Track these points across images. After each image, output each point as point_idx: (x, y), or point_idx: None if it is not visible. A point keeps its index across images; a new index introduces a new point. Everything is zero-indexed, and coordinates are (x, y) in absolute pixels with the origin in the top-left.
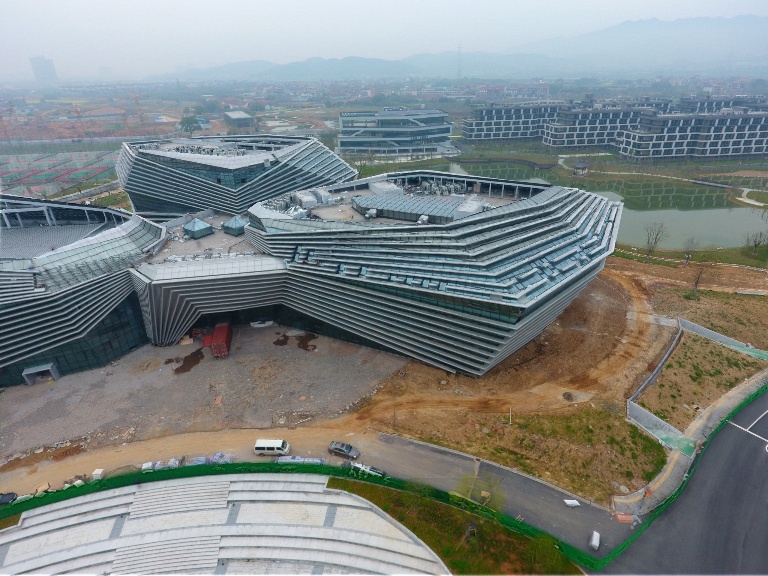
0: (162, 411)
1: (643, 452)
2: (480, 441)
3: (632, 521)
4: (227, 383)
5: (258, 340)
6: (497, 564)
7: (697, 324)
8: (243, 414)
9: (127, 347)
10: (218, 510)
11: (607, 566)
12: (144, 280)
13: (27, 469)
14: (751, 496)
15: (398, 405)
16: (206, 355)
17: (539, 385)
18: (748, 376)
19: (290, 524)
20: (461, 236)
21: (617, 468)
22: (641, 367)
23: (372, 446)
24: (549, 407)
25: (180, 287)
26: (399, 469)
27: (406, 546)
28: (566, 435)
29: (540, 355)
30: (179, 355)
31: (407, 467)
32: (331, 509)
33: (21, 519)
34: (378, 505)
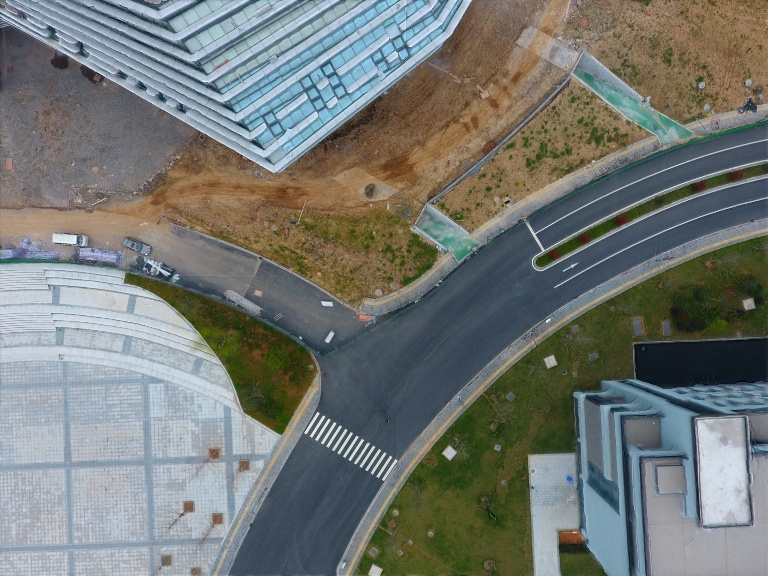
0: None
1: (413, 259)
2: (267, 238)
3: (369, 321)
4: (11, 137)
5: (31, 54)
6: (250, 351)
7: (602, 63)
8: (39, 187)
9: None
10: (43, 291)
11: (331, 354)
12: None
13: None
14: (480, 305)
15: (193, 188)
16: None
17: (347, 170)
18: (599, 157)
19: (101, 308)
20: (192, 33)
21: (380, 275)
22: (475, 148)
23: (164, 240)
24: (344, 204)
25: None
26: (187, 266)
27: (187, 333)
28: (347, 241)
29: (366, 120)
30: None
31: (194, 265)
32: (132, 298)
33: None
34: (167, 301)
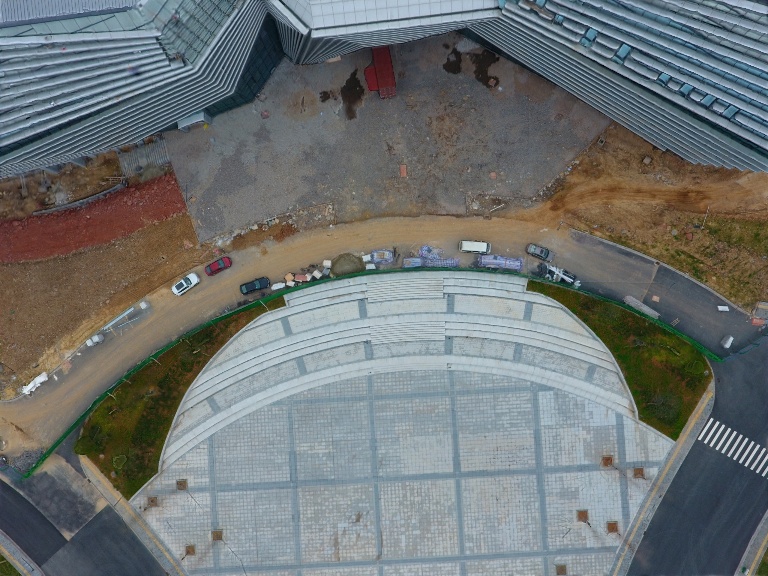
0: (350, 183)
1: None
2: (665, 242)
3: (763, 325)
4: (405, 143)
5: (423, 59)
6: (650, 357)
7: None
8: (434, 194)
9: (267, 72)
10: (437, 300)
11: (727, 359)
12: (296, 26)
13: (257, 249)
14: None
15: (593, 193)
16: (366, 87)
17: (750, 173)
18: None
19: (497, 316)
20: None
21: None
22: None
23: (565, 246)
24: (749, 207)
25: (347, 36)
26: (588, 273)
27: (586, 340)
28: (750, 244)
29: None
30: (332, 85)
31: (595, 271)
32: (529, 305)
33: (286, 302)
34: (568, 308)
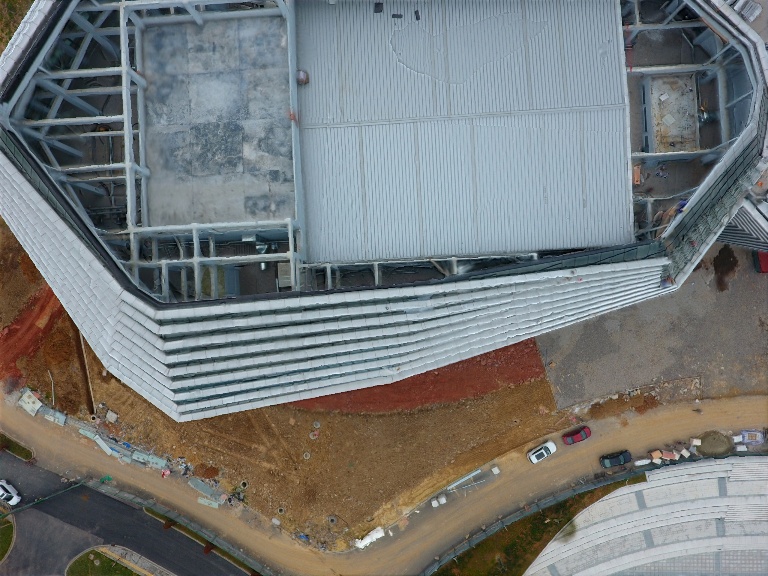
0: (719, 358)
1: None
2: None
3: None
4: None
5: None
6: None
7: None
8: None
9: None
10: None
11: None
12: None
13: (618, 420)
14: None
15: None
16: (740, 259)
17: None
18: None
19: None
20: None
21: None
22: None
23: None
24: None
25: None
26: None
27: None
28: None
29: None
30: None
31: None
32: None
33: (647, 477)
34: None
